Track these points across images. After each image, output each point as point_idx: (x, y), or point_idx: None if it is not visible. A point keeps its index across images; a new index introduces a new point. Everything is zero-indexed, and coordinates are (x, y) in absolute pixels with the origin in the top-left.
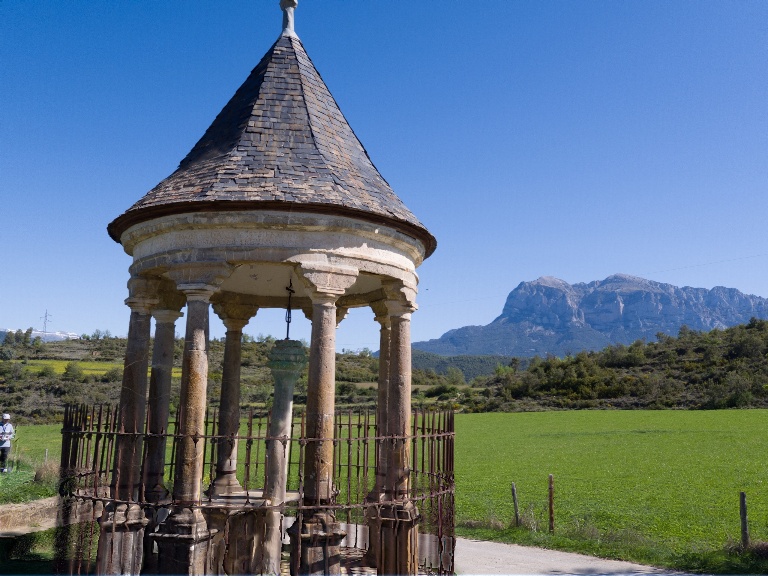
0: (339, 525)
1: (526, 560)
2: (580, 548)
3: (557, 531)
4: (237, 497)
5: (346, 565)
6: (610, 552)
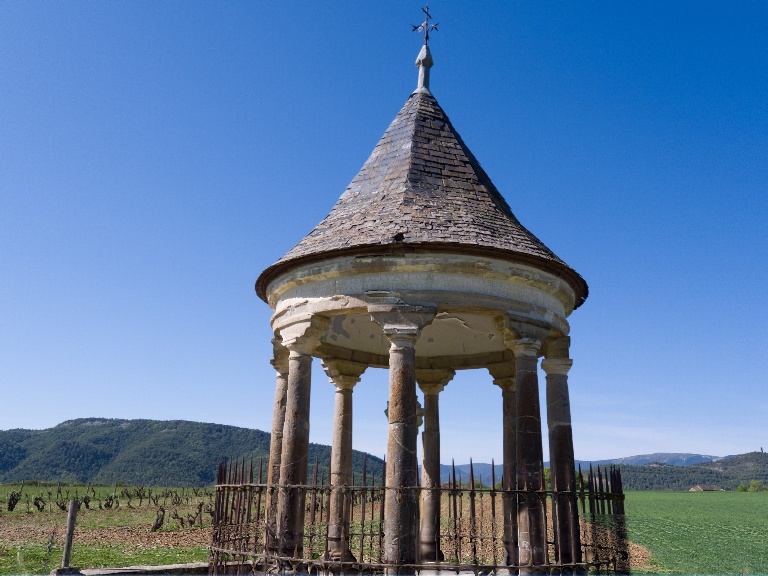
0: (320, 557)
1: None
2: None
3: None
4: None
5: None
6: None
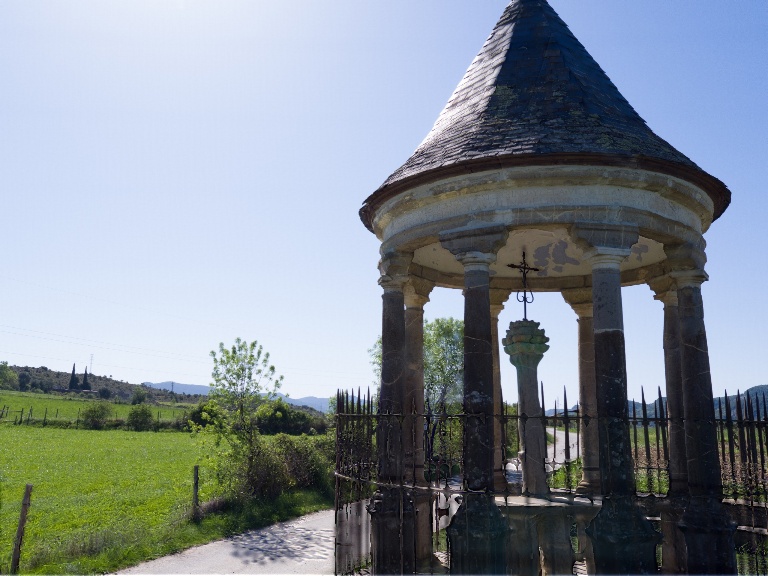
0: None
1: (196, 573)
2: (136, 557)
3: (21, 564)
4: (562, 501)
5: (446, 571)
6: (169, 547)
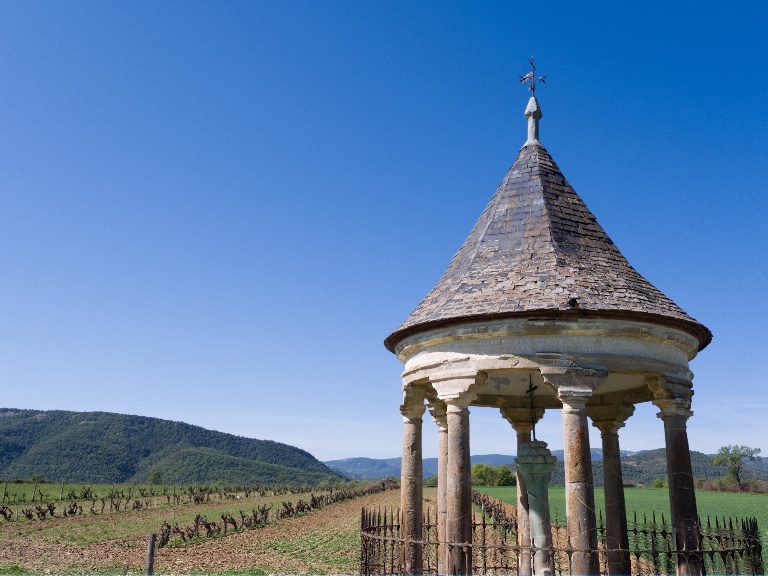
0: None
1: None
2: None
3: None
4: None
5: None
6: None
